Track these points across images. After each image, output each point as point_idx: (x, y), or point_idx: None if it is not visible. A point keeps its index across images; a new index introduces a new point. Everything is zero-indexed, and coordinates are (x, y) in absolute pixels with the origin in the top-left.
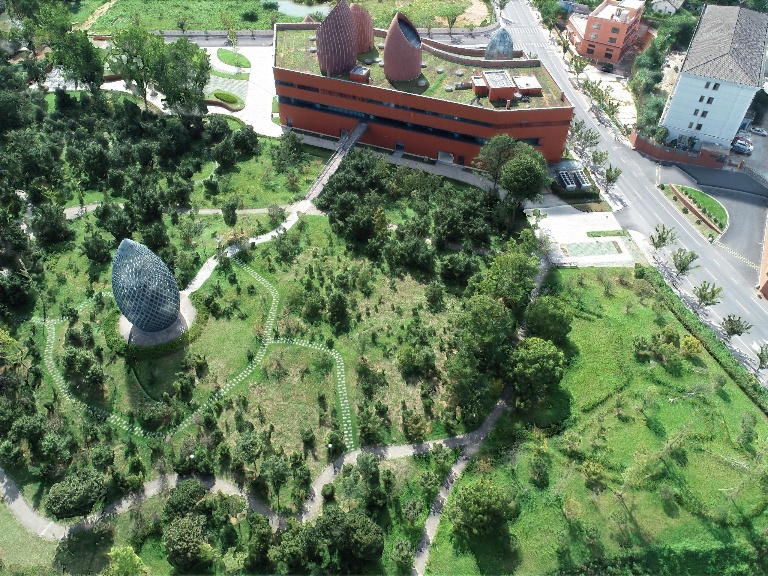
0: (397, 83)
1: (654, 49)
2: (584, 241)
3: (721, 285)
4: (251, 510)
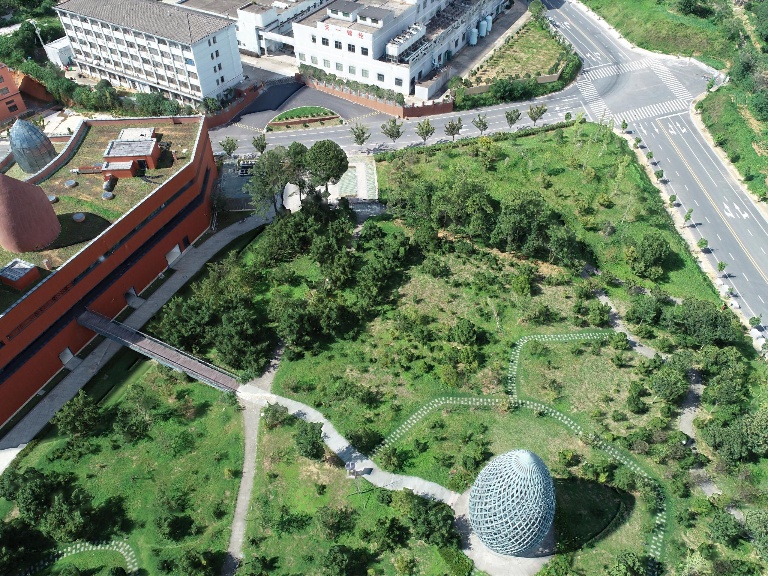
0: (61, 241)
1: (56, 70)
2: None
3: None
4: (706, 394)
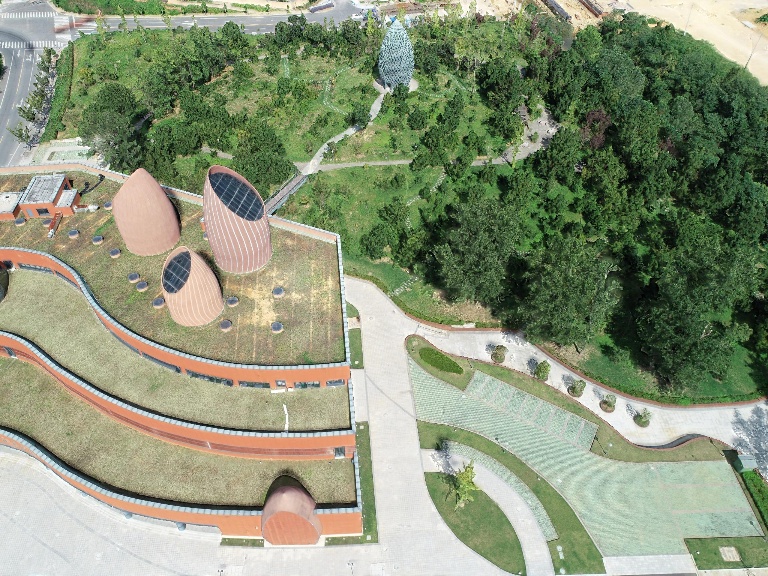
0: None
1: None
2: (74, 160)
3: (4, 133)
4: None
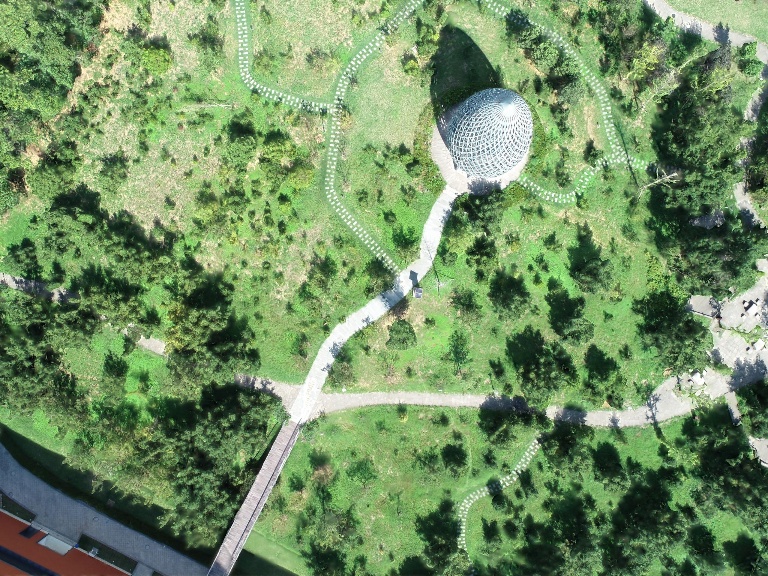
0: None
1: None
2: None
3: None
4: None
